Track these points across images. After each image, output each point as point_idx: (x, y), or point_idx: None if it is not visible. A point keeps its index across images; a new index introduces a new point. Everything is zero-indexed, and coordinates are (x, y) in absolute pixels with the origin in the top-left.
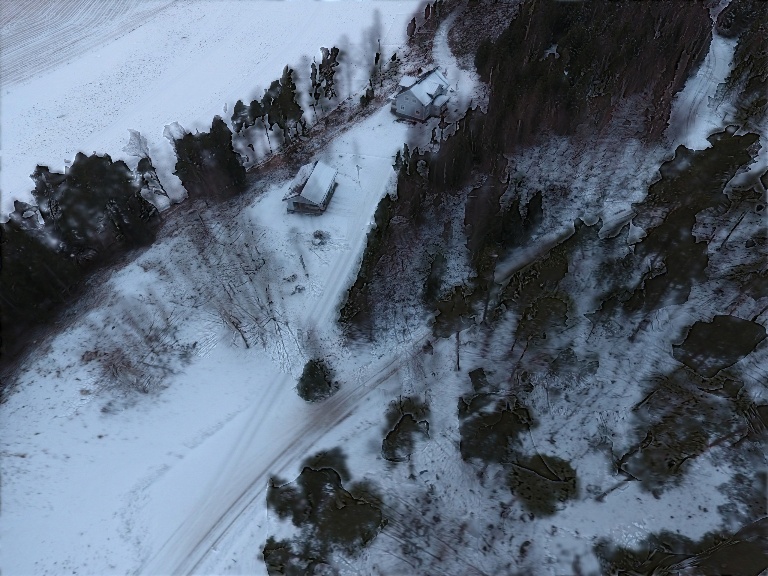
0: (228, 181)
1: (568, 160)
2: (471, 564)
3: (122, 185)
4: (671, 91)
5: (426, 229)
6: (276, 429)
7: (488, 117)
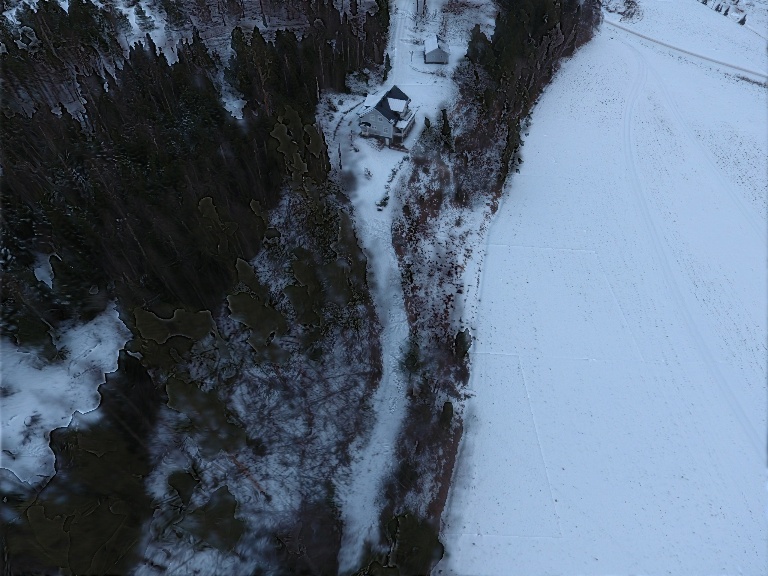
0: None
1: None
2: None
3: None
4: None
5: None
6: (400, 2)
7: None
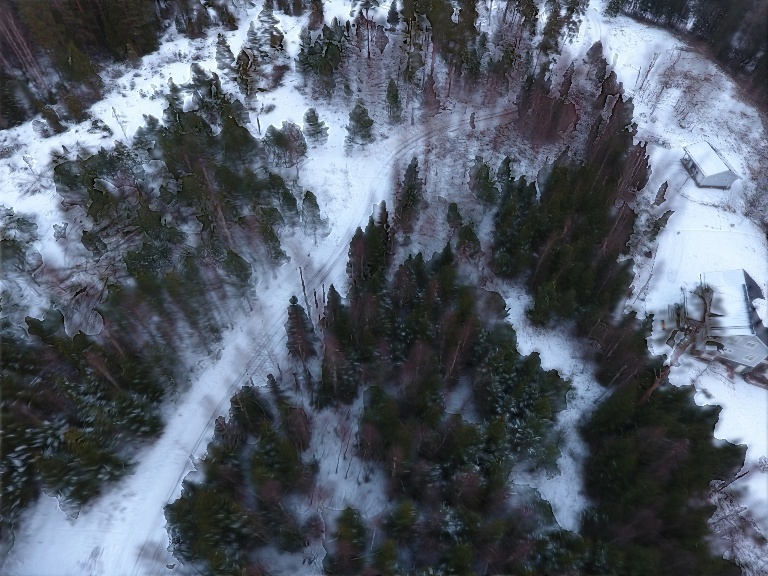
0: None
1: None
2: (509, 41)
3: None
4: None
5: None
6: None
7: (603, 187)
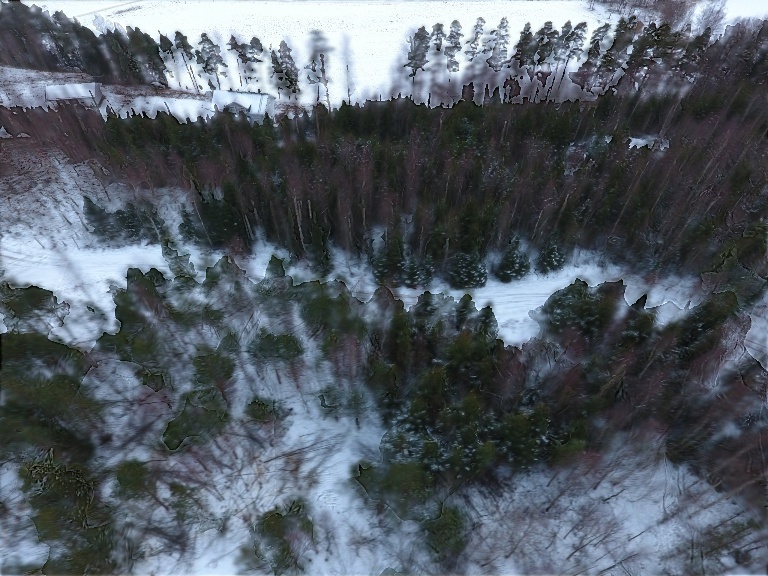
0: (88, 68)
1: (81, 188)
2: None
3: (21, 25)
4: (157, 211)
5: (20, 150)
6: None
7: None
